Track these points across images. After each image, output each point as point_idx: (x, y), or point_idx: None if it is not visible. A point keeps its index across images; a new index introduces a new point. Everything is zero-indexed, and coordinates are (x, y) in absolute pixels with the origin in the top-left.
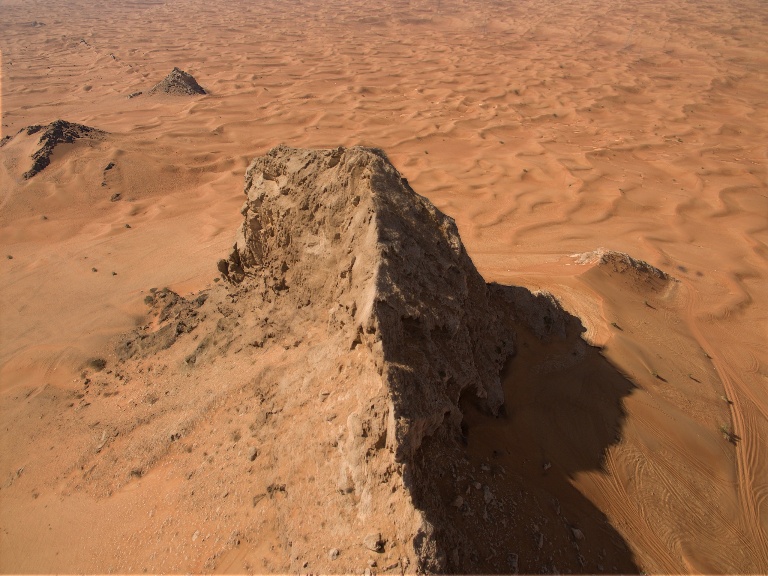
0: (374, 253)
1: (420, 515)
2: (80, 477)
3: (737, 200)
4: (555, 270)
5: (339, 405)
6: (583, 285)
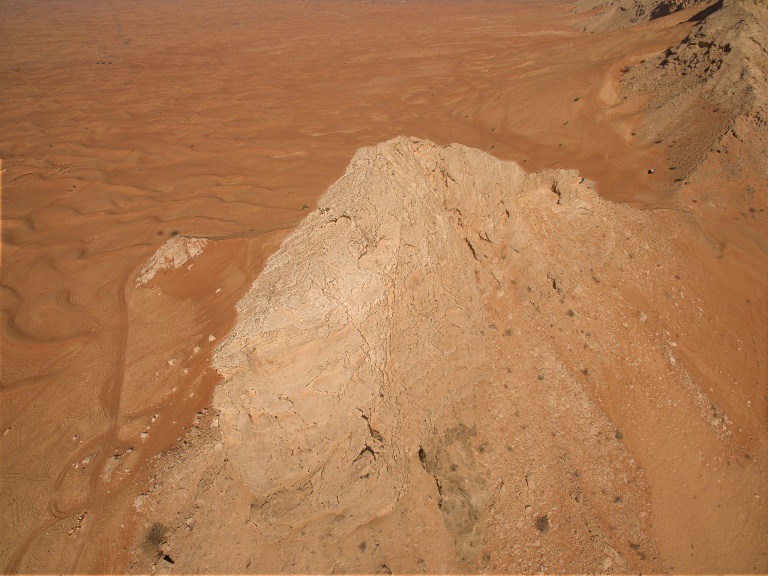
0: (487, 159)
1: (581, 184)
2: (648, 567)
3: (8, 213)
4: (217, 264)
5: (551, 218)
6: (264, 236)
